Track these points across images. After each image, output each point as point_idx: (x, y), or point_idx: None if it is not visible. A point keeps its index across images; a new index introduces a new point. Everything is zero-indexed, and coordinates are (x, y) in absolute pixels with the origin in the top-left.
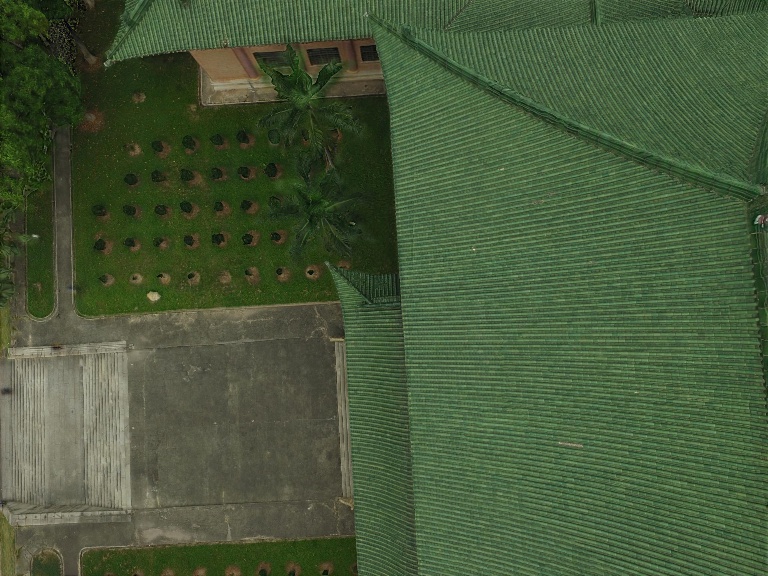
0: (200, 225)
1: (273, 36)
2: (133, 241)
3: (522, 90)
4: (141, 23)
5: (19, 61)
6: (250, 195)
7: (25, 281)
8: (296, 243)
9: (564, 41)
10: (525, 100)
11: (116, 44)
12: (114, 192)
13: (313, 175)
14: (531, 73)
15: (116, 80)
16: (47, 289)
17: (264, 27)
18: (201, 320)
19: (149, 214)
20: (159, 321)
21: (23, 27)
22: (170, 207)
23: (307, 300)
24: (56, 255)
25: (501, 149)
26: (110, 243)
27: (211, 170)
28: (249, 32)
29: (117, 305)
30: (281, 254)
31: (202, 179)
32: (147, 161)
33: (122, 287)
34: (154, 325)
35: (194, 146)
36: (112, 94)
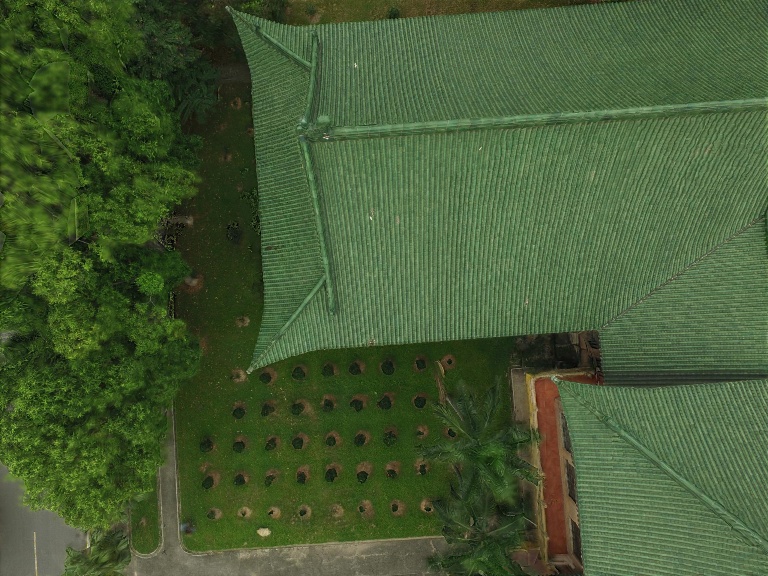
0: (310, 456)
1: (422, 335)
2: (243, 479)
3: (742, 499)
4: (287, 332)
5: (156, 368)
6: (361, 424)
7: (128, 515)
8: (410, 475)
9: (763, 404)
10: (765, 546)
11: (262, 356)
12: (219, 422)
13: (426, 403)
14: (741, 463)
15: (218, 302)
16: (152, 524)
17: (413, 328)
18: (313, 556)
19: (256, 445)
20: (269, 557)
21: (162, 338)
22: (278, 437)
23: (423, 534)
24: (160, 488)
25: (722, 567)
26: (216, 476)
27: (320, 398)
28: (397, 333)
29: (226, 541)
30: (395, 487)
31: (311, 407)
32: (253, 389)
33: (230, 522)
34: (264, 561)
35: (304, 377)
36: (214, 317)
